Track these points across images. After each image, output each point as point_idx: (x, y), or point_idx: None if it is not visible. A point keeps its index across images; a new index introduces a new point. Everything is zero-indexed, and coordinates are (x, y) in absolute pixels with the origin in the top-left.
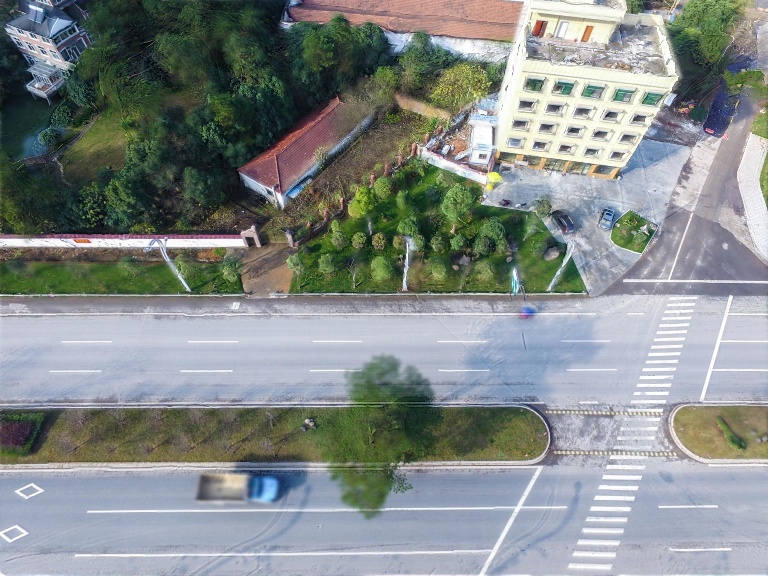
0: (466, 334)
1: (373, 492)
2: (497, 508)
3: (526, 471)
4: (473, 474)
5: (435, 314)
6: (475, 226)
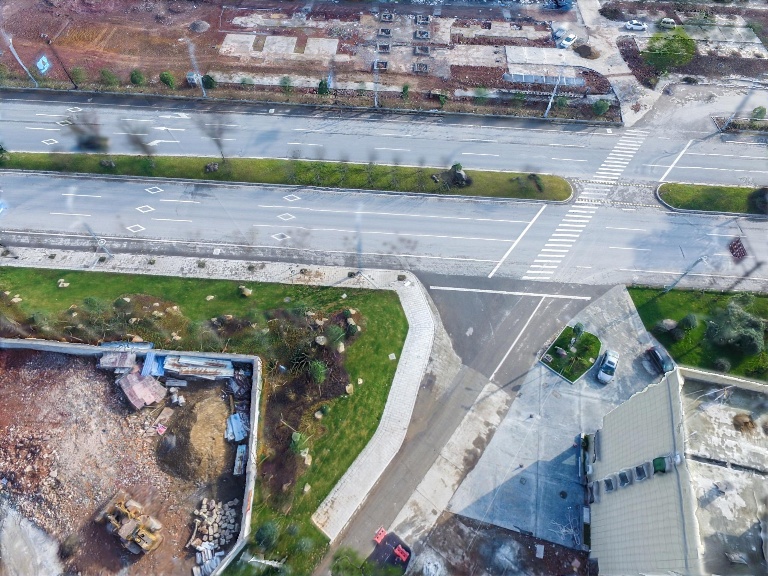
0: (732, 261)
1: (763, 178)
2: (685, 167)
3: (670, 180)
4: (703, 181)
5: (765, 279)
6: (761, 366)
